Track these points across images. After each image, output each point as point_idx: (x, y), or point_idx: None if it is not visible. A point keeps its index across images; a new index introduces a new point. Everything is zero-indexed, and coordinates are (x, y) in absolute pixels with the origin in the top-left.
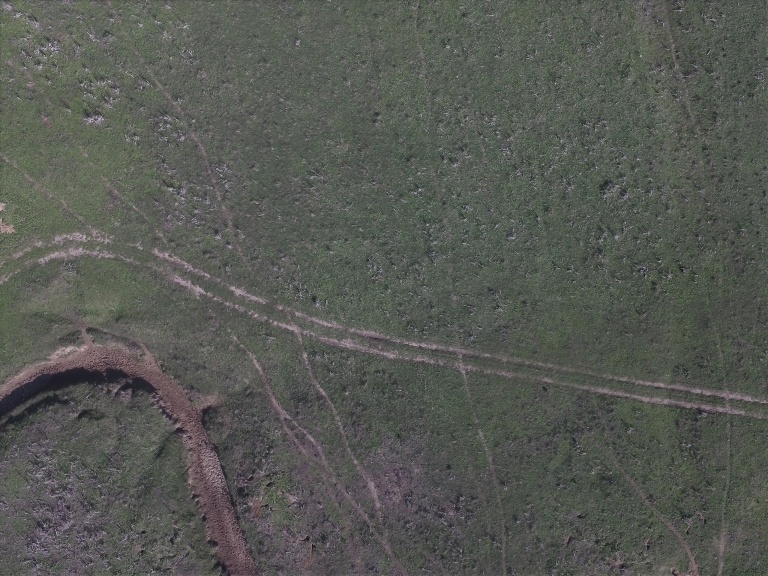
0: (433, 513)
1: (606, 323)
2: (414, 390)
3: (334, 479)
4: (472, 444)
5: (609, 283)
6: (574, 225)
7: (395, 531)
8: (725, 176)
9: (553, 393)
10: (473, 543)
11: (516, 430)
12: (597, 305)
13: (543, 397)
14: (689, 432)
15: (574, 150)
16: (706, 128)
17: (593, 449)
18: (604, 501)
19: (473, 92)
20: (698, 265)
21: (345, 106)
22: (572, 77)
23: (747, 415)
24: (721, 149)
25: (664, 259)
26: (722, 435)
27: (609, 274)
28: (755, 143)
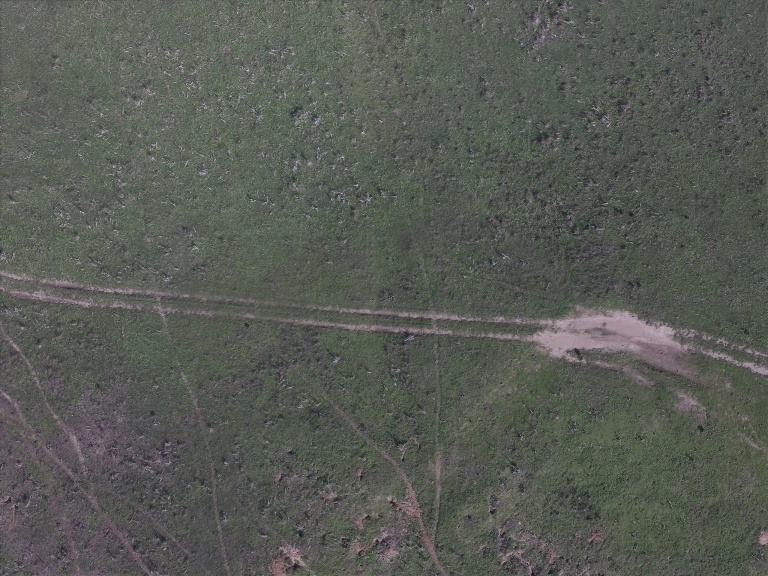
0: (139, 462)
1: (306, 253)
2: (112, 338)
3: (34, 436)
4: (176, 388)
5: (307, 212)
6: (267, 155)
7: (100, 484)
8: (419, 94)
9: (256, 329)
10: (182, 489)
11: (220, 370)
12: (297, 235)
13: (245, 333)
14: (398, 357)
15: (262, 79)
16: (396, 47)
17: (300, 382)
18: (314, 434)
19: (153, 28)
20: (397, 186)
21: (22, 52)
22: (255, 5)
23: (455, 334)
24: (413, 67)
25: (362, 183)
26: (430, 356)
27: (306, 203)
28: (447, 58)
